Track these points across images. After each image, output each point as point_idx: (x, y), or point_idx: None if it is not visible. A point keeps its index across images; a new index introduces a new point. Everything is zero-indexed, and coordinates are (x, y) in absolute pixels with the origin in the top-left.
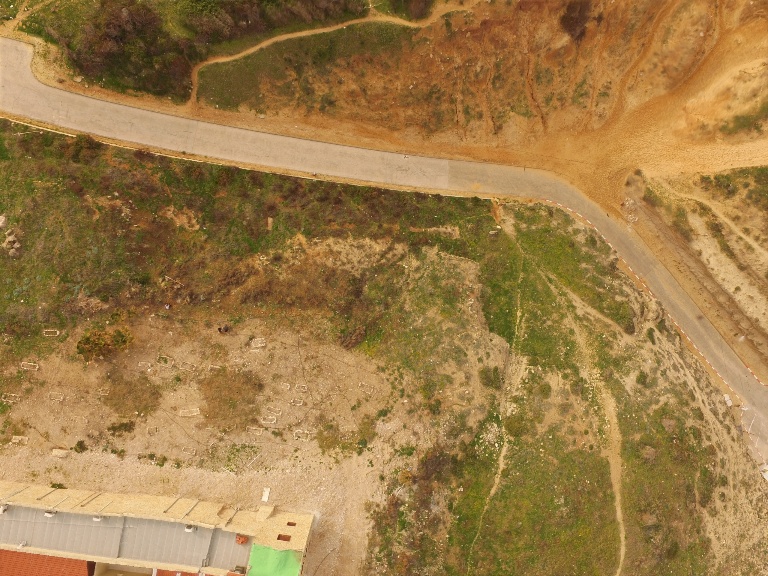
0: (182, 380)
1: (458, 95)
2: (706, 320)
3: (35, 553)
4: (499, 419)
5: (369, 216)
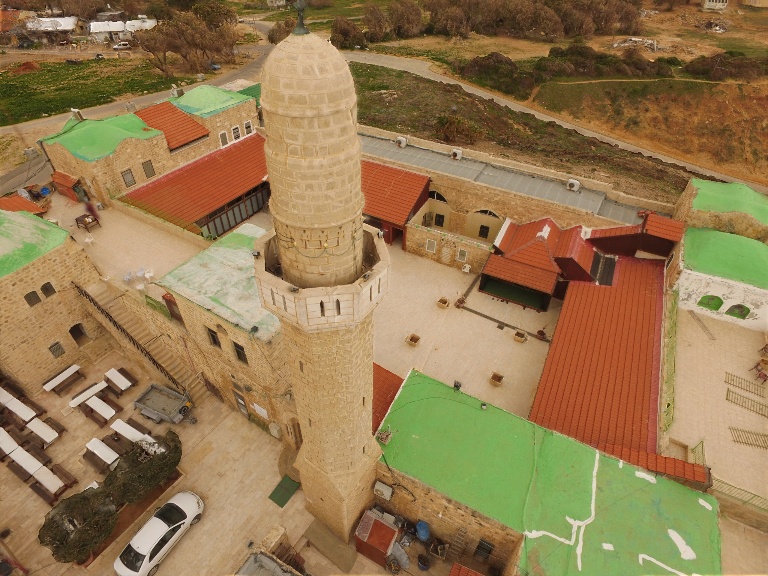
0: None
1: (746, 140)
2: None
3: (373, 155)
4: None
5: None
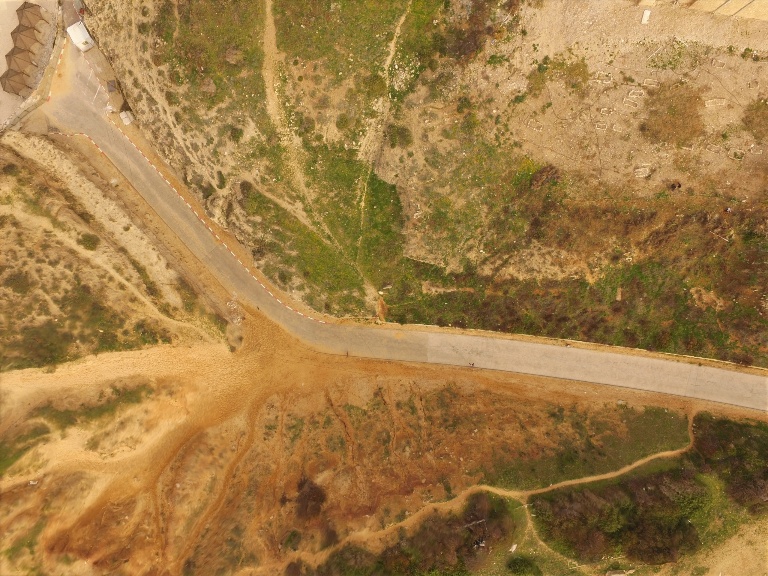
0: (721, 135)
1: (424, 425)
2: (149, 202)
3: None
4: (391, 94)
5: (517, 303)
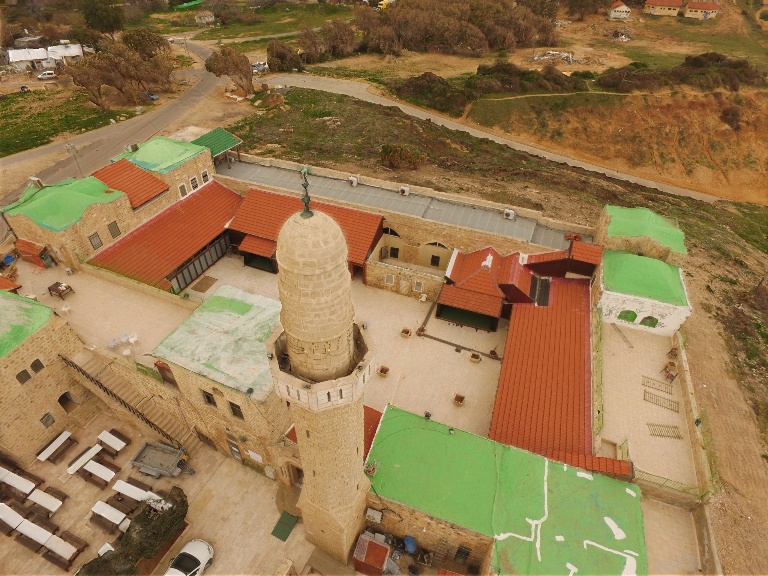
0: (465, 190)
1: (654, 145)
2: None
3: (328, 198)
4: None
5: None
